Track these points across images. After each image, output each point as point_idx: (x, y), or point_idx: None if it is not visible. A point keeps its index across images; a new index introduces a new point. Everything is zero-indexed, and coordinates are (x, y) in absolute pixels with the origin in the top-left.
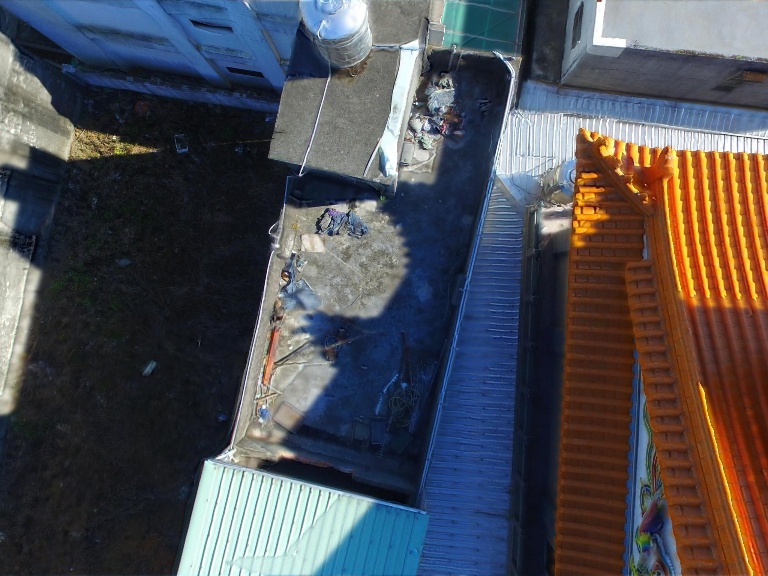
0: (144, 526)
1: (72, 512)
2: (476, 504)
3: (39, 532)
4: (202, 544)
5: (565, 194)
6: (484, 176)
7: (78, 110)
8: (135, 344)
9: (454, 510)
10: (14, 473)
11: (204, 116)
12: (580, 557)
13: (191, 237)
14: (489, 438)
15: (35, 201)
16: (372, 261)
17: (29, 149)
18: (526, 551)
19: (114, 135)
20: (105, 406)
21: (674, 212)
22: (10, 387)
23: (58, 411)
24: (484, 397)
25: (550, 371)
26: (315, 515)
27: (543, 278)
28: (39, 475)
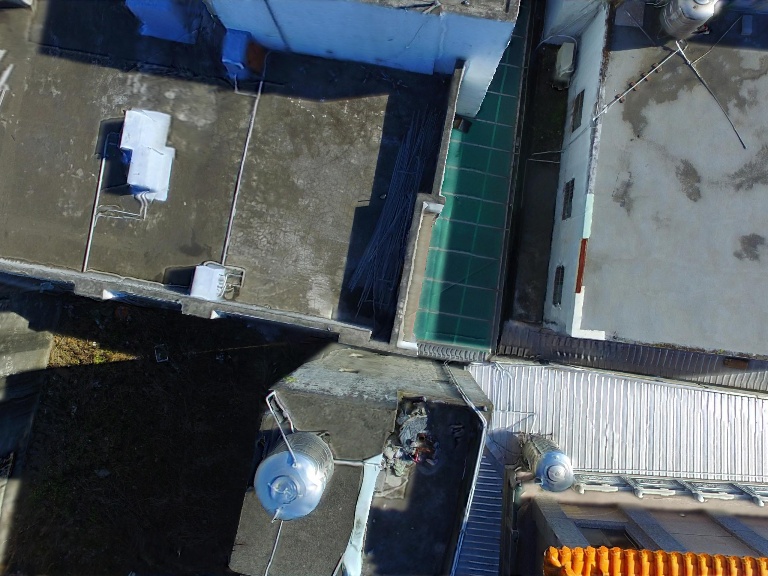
0: None
1: None
2: None
3: None
4: None
5: (543, 488)
6: (457, 506)
7: (58, 317)
8: (114, 554)
9: None
10: None
11: (185, 322)
12: None
13: (171, 448)
14: None
15: (12, 422)
16: None
17: (5, 379)
18: None
19: (94, 341)
20: None
21: None
22: None
23: None
24: None
25: None
26: None
27: (522, 550)
28: None
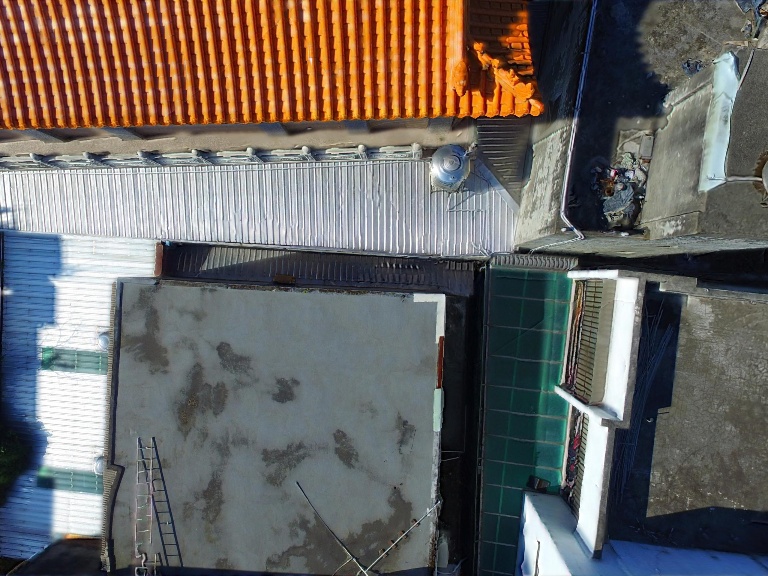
0: None
1: None
2: None
3: None
4: None
5: None
6: None
7: None
8: None
9: None
10: None
11: None
12: None
13: None
14: None
15: None
16: (675, 37)
17: None
18: None
19: None
20: None
21: (442, 43)
22: None
23: None
24: None
25: None
26: None
27: None
28: None
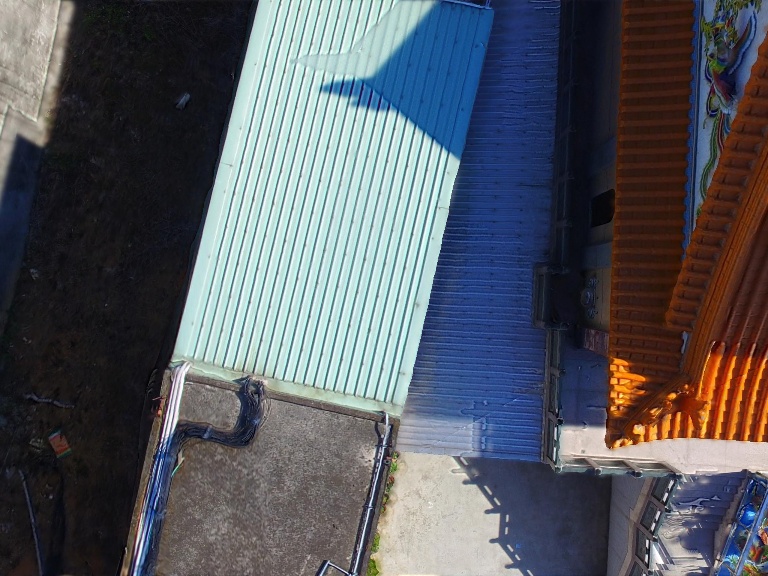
0: (179, 260)
1: (106, 247)
2: (519, 177)
3: (73, 268)
4: (266, 43)
5: None
6: None
7: None
8: (169, 77)
9: (497, 185)
10: (48, 208)
11: None
12: (648, 40)
13: None
14: (532, 110)
15: None
16: None
17: None
18: (572, 199)
19: None
20: (139, 141)
21: None
22: (44, 118)
23: (92, 144)
24: (526, 70)
25: (595, 19)
26: (379, 14)
27: None
28: (73, 211)
